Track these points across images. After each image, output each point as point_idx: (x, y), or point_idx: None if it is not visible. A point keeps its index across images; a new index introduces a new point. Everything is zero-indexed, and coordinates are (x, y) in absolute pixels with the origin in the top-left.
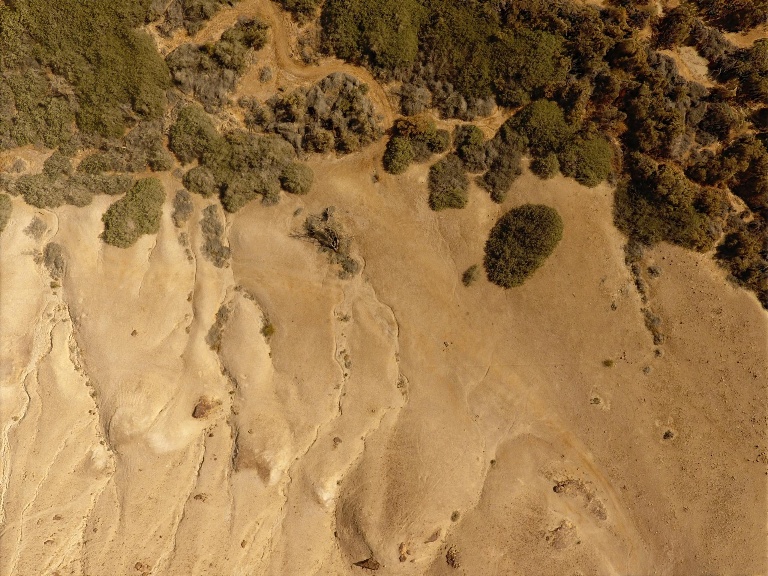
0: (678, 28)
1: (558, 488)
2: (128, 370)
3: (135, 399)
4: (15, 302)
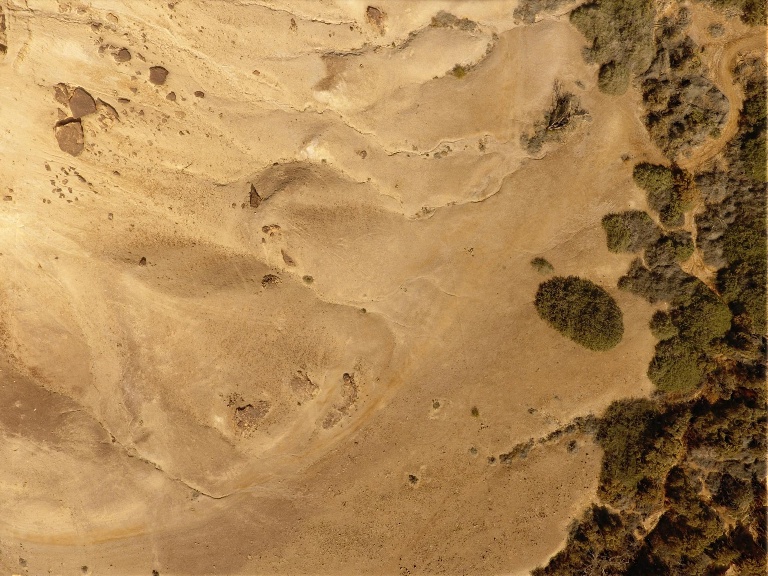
0: None
1: (348, 377)
2: None
3: None
4: None
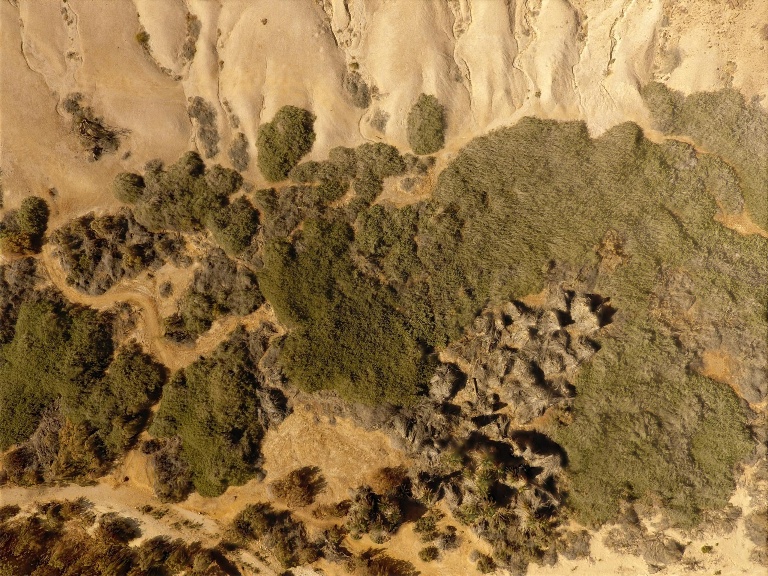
0: None
1: None
2: None
3: None
4: (386, 43)
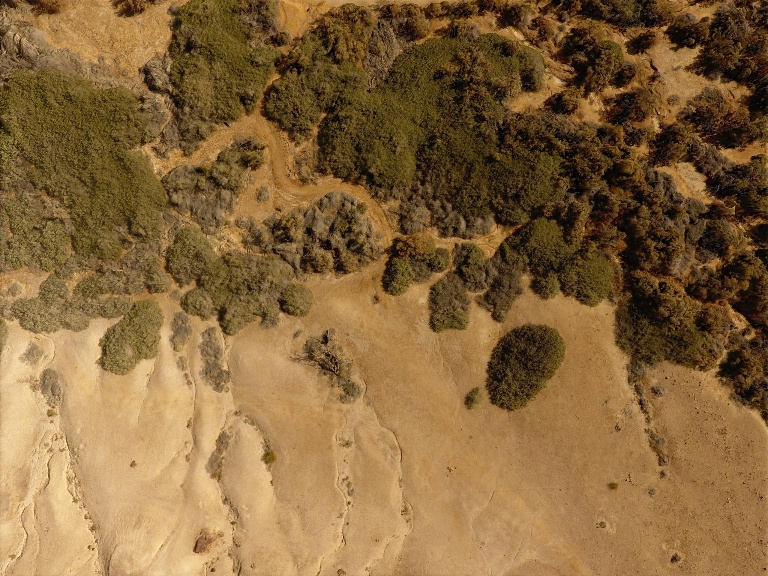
0: (675, 147)
1: None
2: (127, 503)
3: (135, 535)
4: (11, 433)
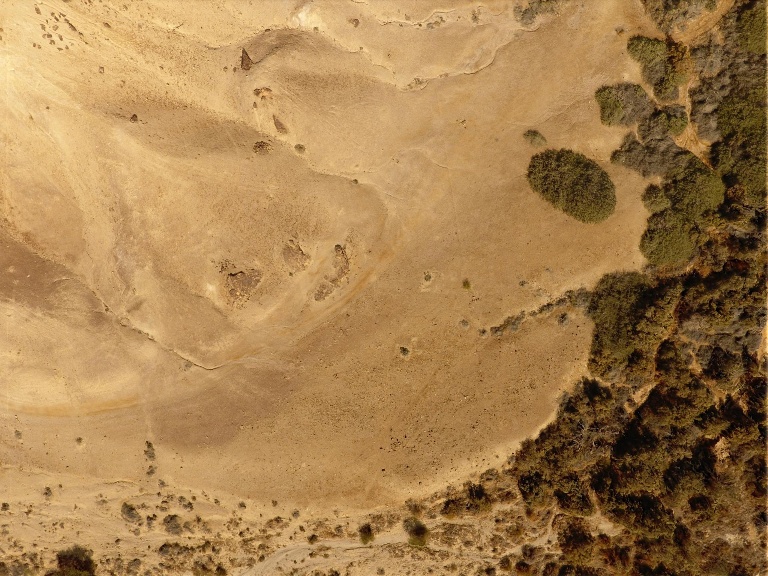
0: None
1: (339, 248)
2: None
3: None
4: None
